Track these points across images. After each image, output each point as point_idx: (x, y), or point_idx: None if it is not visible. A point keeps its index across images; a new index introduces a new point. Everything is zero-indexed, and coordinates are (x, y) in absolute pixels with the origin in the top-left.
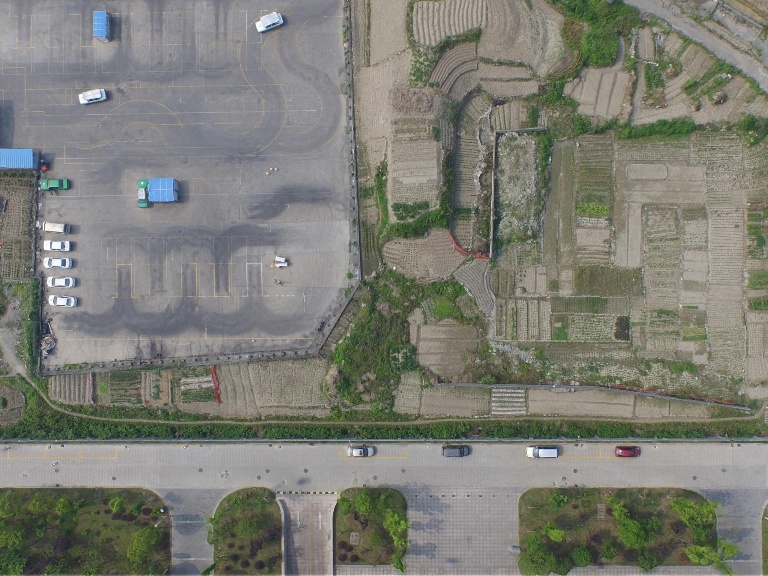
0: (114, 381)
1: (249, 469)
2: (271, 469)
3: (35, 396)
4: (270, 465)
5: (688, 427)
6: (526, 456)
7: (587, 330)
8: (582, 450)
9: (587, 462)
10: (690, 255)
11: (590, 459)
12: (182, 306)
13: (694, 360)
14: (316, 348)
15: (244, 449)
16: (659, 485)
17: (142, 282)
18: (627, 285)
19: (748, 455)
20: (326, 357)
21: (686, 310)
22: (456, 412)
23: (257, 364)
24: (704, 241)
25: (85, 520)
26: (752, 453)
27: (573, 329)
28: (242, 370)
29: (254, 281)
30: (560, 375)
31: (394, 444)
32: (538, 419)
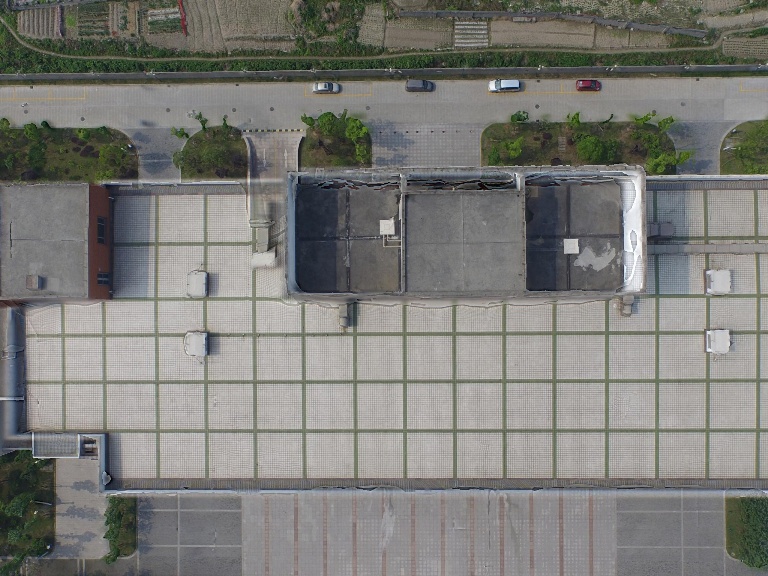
0: (82, 14)
1: (216, 108)
2: (238, 108)
3: (4, 32)
4: (237, 104)
5: (647, 55)
6: (489, 91)
7: None
8: (544, 86)
9: (549, 97)
10: None
11: (552, 94)
12: None
13: None
14: None
15: (211, 89)
16: (619, 119)
17: None
18: None
19: (707, 89)
20: None
21: None
22: (419, 45)
23: None
24: None
25: (54, 158)
26: (711, 87)
27: None
28: (208, 2)
29: None
30: (522, 7)
31: (359, 82)
32: (500, 51)
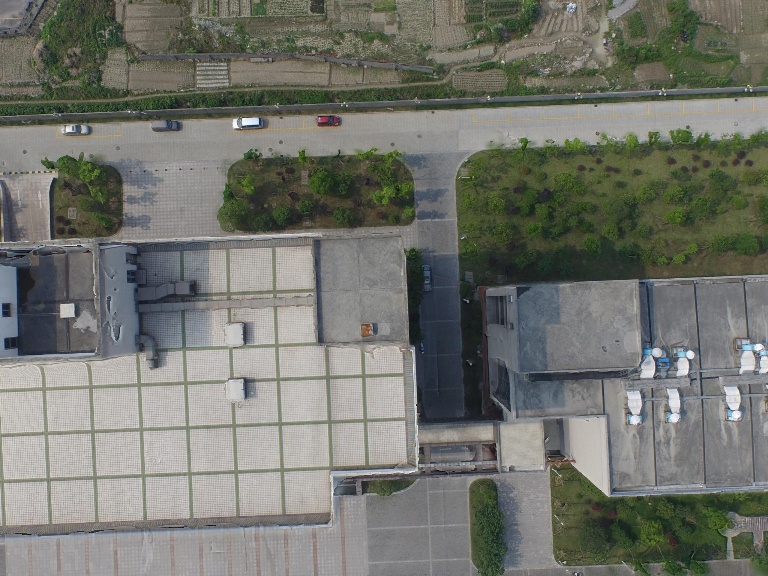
0: None
1: None
2: None
3: None
4: None
5: (379, 91)
6: (233, 129)
7: (284, 5)
8: (287, 122)
9: (291, 133)
10: None
11: (294, 130)
12: None
13: (386, 30)
14: (25, 27)
15: None
16: (360, 153)
17: None
18: None
19: (442, 121)
20: (34, 35)
21: None
22: (163, 86)
23: None
24: None
25: None
26: (445, 119)
27: (271, 5)
28: None
29: None
30: (260, 48)
31: (108, 123)
32: (240, 90)
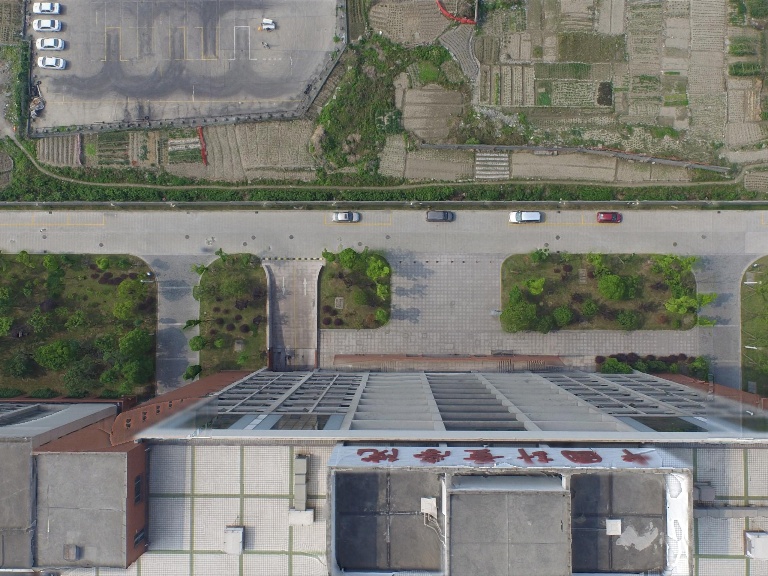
0: (102, 142)
1: (235, 236)
2: (257, 236)
3: (23, 159)
4: (256, 232)
5: (669, 189)
6: (509, 222)
7: (570, 95)
8: (564, 217)
9: (569, 229)
10: (672, 22)
11: (572, 225)
12: (170, 69)
13: (675, 126)
14: (302, 111)
15: (230, 216)
16: (640, 251)
17: (131, 45)
18: (610, 51)
19: (728, 222)
20: (312, 119)
21: (668, 76)
22: (440, 176)
23: (244, 126)
24: (686, 8)
25: (72, 285)
26: (732, 220)
27: (556, 94)
28: (229, 132)
29: (242, 44)
30: (543, 140)
31: (379, 211)
32: (521, 183)
